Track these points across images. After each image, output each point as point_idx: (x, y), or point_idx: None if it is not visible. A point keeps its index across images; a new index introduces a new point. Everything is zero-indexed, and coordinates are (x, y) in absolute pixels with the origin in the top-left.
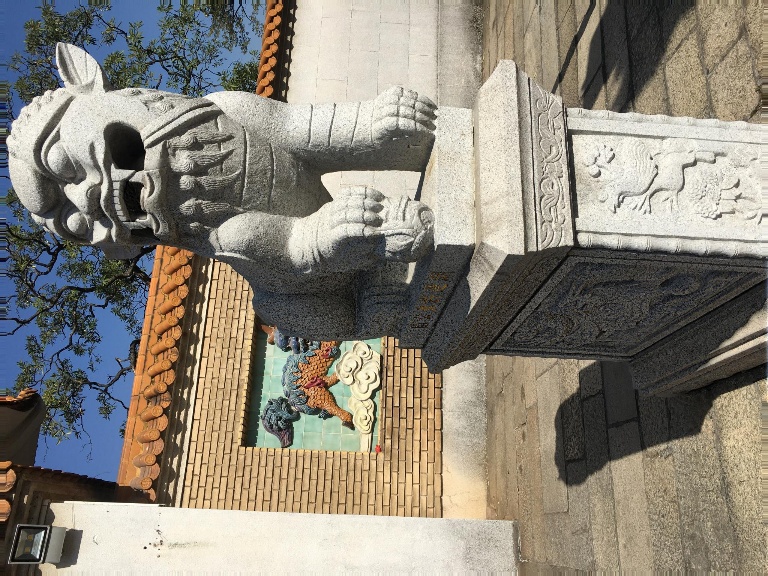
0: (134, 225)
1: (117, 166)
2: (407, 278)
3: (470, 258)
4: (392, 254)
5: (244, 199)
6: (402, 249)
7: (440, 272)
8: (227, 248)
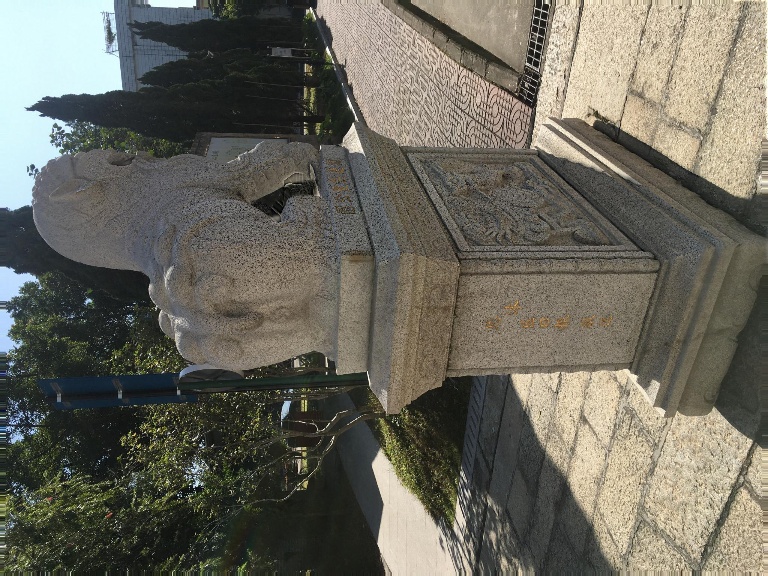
0: None
1: None
2: None
3: (344, 149)
4: None
5: None
6: None
7: None
8: None
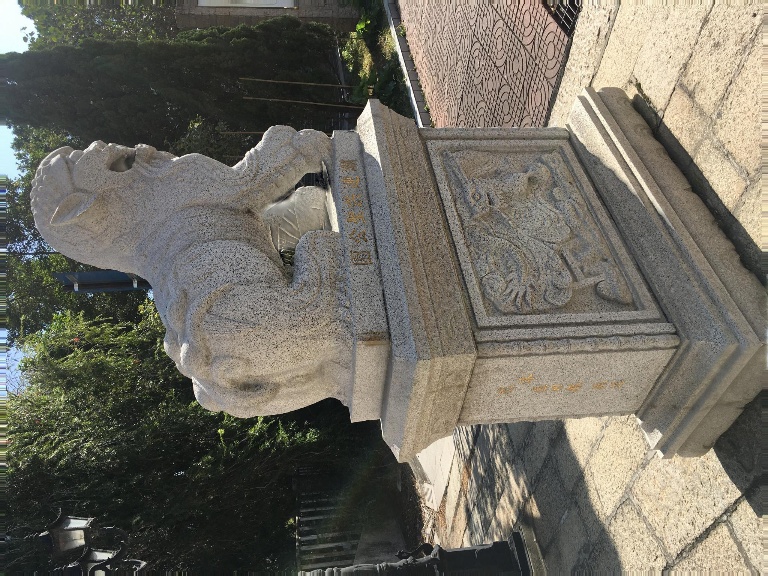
0: None
1: None
2: None
3: (359, 140)
4: None
5: None
6: None
7: None
8: None
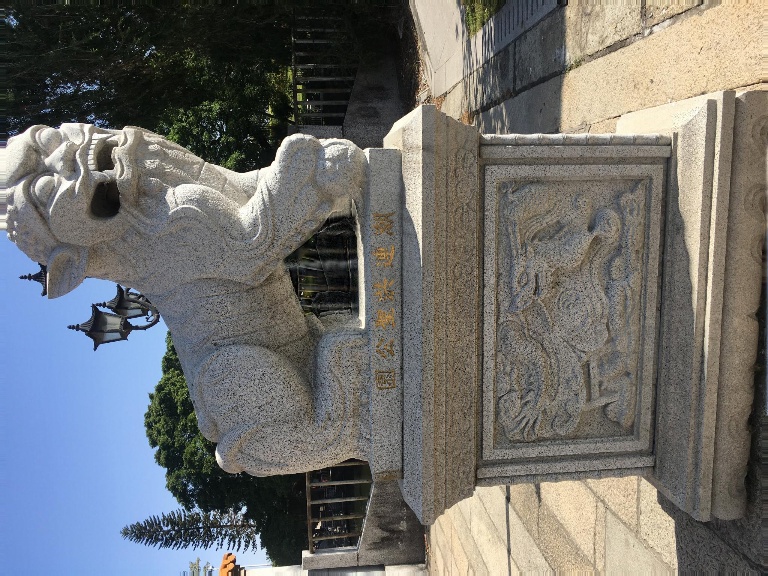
0: (100, 174)
1: (99, 133)
2: (361, 326)
3: (401, 172)
4: (332, 163)
5: (201, 177)
6: (339, 154)
7: (382, 216)
8: (182, 200)
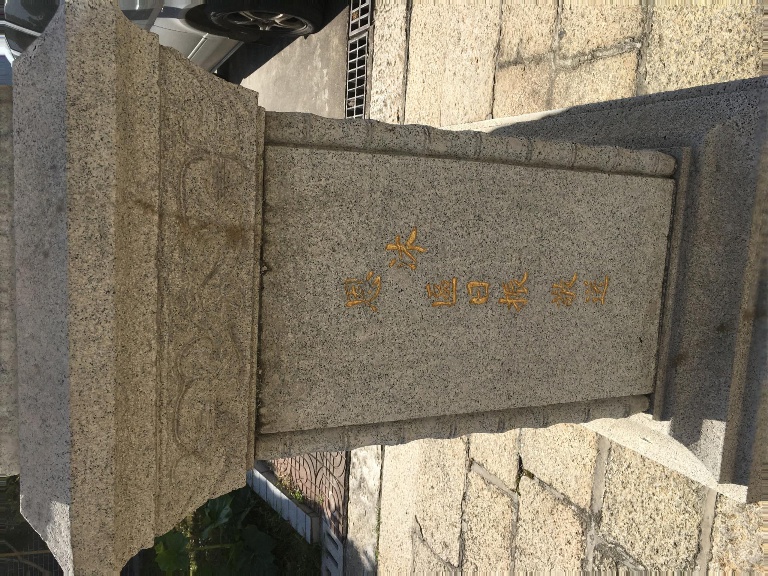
0: None
1: None
2: None
3: None
4: None
5: None
6: None
7: None
8: None
